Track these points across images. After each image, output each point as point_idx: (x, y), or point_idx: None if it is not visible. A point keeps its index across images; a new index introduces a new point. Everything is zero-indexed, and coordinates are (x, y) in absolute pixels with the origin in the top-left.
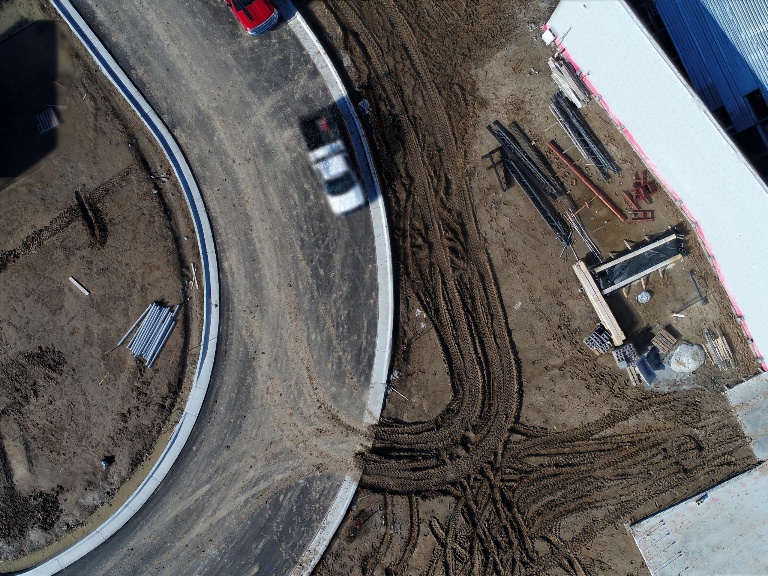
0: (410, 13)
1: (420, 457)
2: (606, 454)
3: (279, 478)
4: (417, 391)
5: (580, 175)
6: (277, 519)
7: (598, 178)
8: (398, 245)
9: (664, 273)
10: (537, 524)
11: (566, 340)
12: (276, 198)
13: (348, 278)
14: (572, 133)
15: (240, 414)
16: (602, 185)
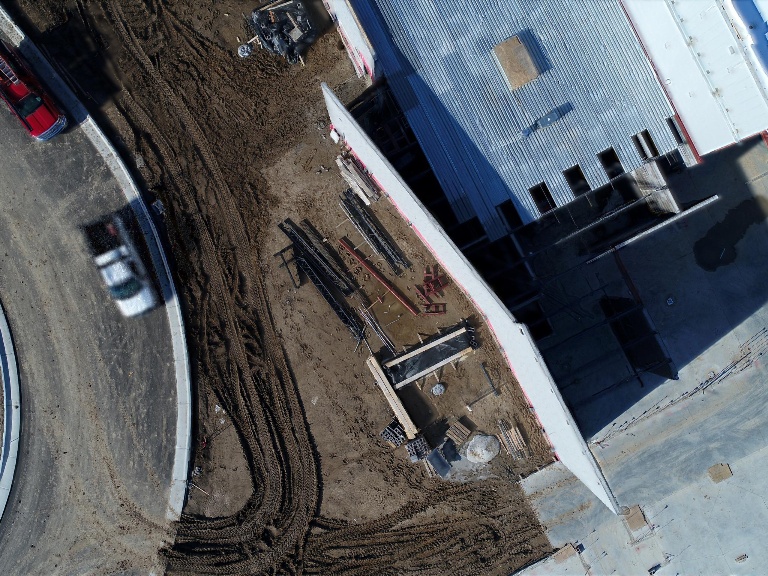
0: (200, 114)
1: (223, 552)
2: (405, 545)
3: None
4: (219, 486)
5: (371, 271)
6: None
7: (390, 273)
8: (195, 343)
9: (457, 365)
10: None
11: (363, 433)
12: (74, 299)
13: (147, 377)
14: (362, 229)
15: (44, 514)
16: (394, 280)
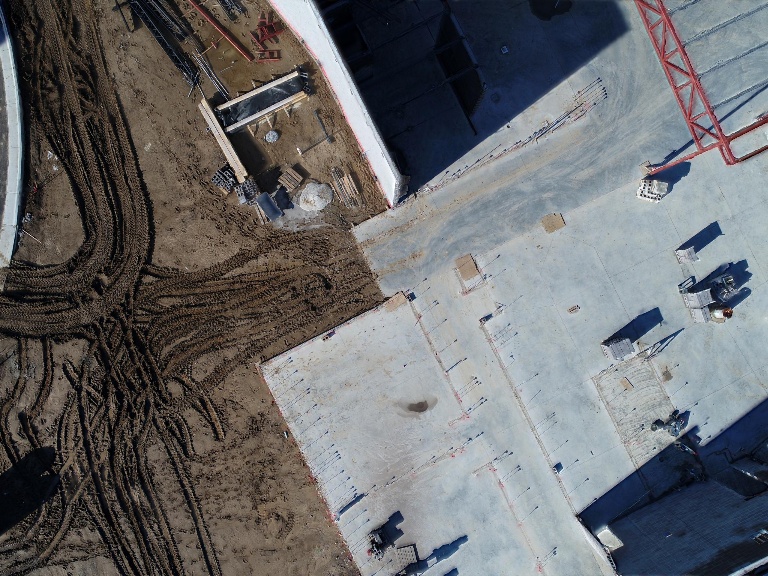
0: None
1: (53, 300)
2: (236, 293)
3: None
4: (50, 234)
5: (205, 15)
6: None
7: (225, 19)
8: (28, 87)
9: (291, 112)
10: (170, 365)
11: (196, 180)
12: None
13: None
14: None
15: None
16: (229, 25)
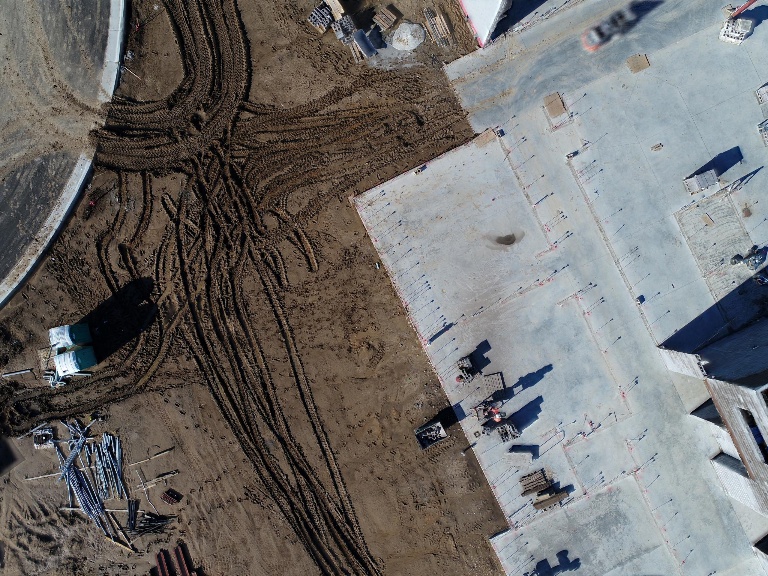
0: None
1: (153, 135)
2: (330, 129)
3: (16, 156)
4: (150, 72)
5: None
6: (14, 196)
7: None
8: None
9: None
10: (265, 199)
11: (292, 20)
12: None
13: None
14: None
15: None
16: None
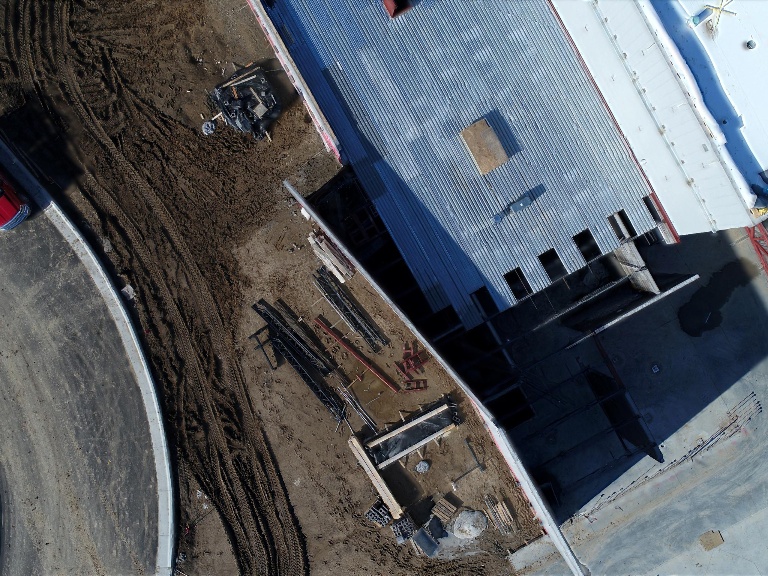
0: (167, 195)
1: None
2: None
3: None
4: (204, 571)
5: (349, 349)
6: None
7: (368, 350)
8: (173, 428)
9: (441, 441)
10: None
11: (348, 513)
12: (47, 389)
13: (125, 465)
14: (338, 308)
15: None
16: (373, 357)
